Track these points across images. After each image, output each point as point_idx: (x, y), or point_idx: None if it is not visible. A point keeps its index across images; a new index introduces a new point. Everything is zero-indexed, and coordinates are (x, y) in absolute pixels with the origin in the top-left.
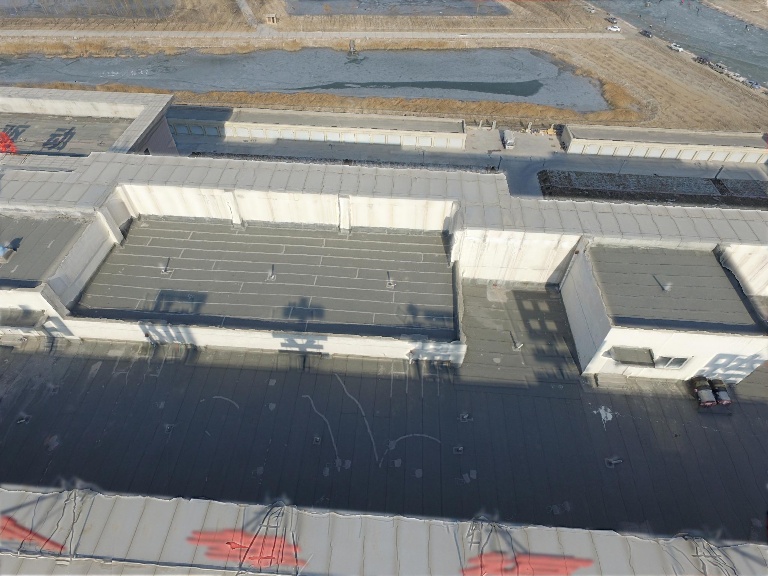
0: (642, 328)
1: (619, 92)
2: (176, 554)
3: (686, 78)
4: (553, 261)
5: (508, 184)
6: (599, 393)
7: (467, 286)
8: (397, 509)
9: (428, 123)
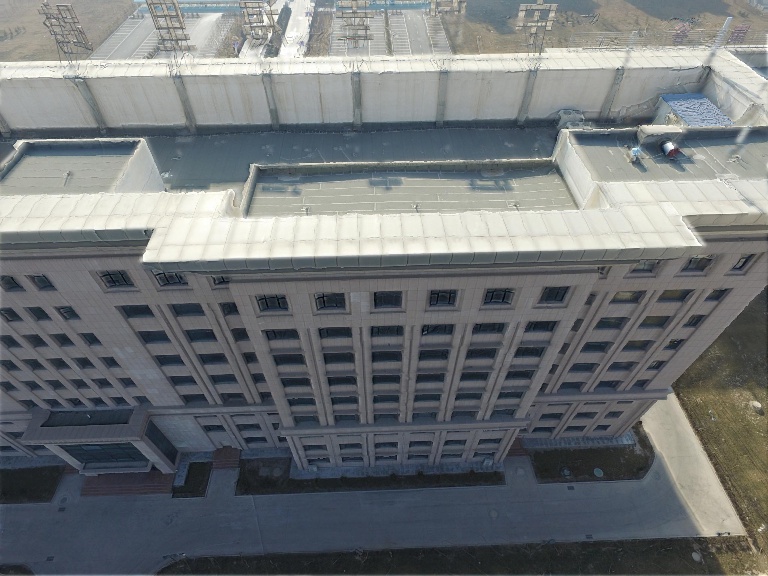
0: (116, 150)
1: None
2: None
3: None
4: None
5: None
6: None
7: None
8: (308, 138)
9: None
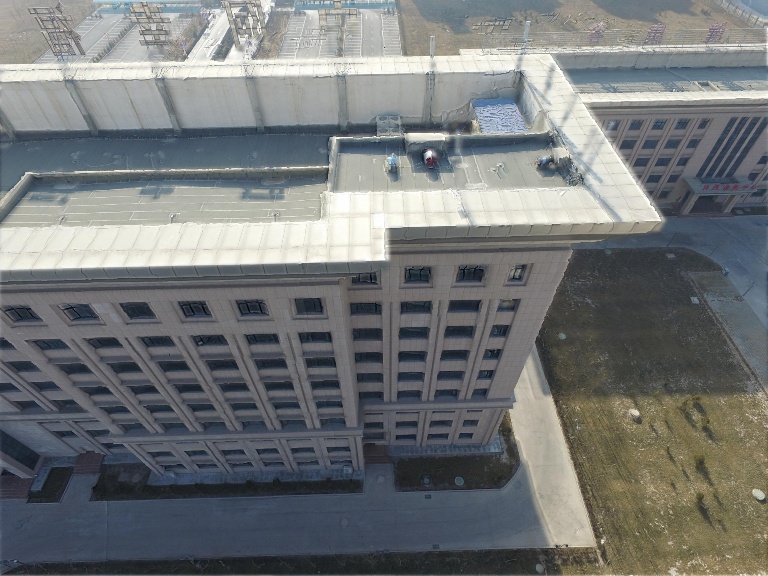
0: None
1: None
2: None
3: None
4: None
5: None
6: None
7: None
8: (124, 144)
9: None
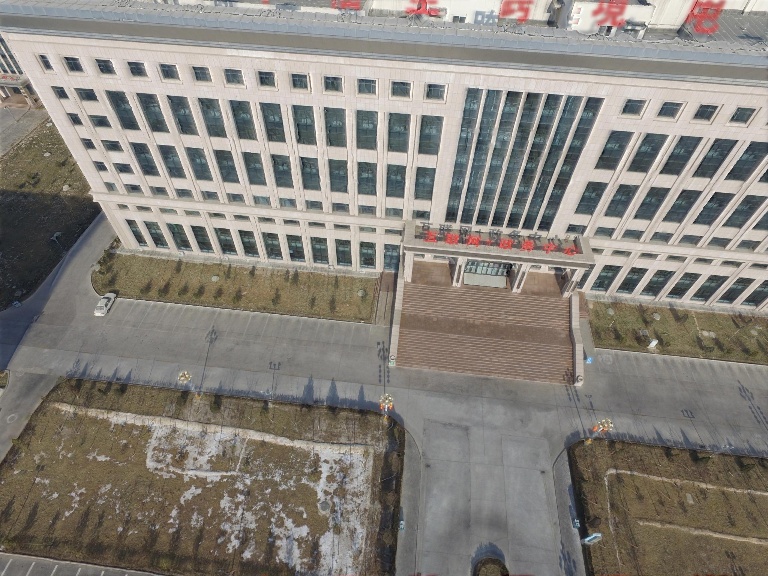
0: None
1: None
2: None
3: None
4: None
5: None
6: None
7: (378, 14)
8: None
9: None
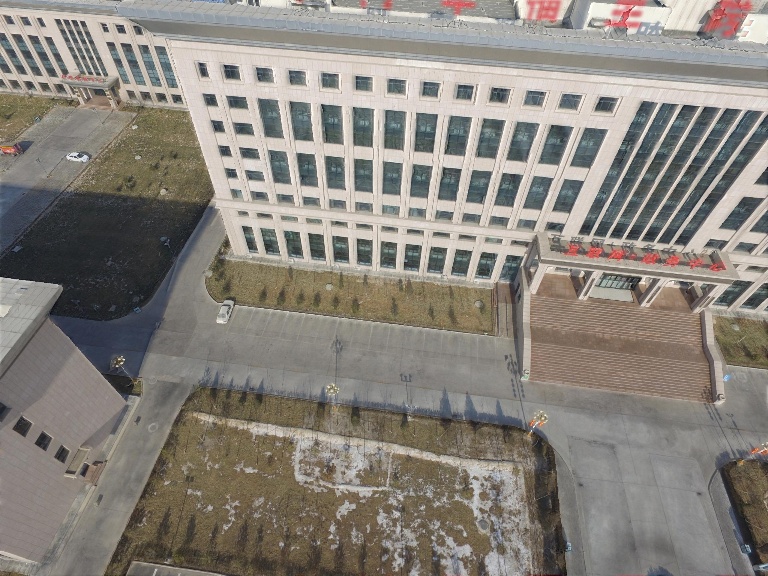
0: None
1: None
2: (424, 24)
3: None
4: (567, 3)
5: None
6: None
7: None
8: None
9: None
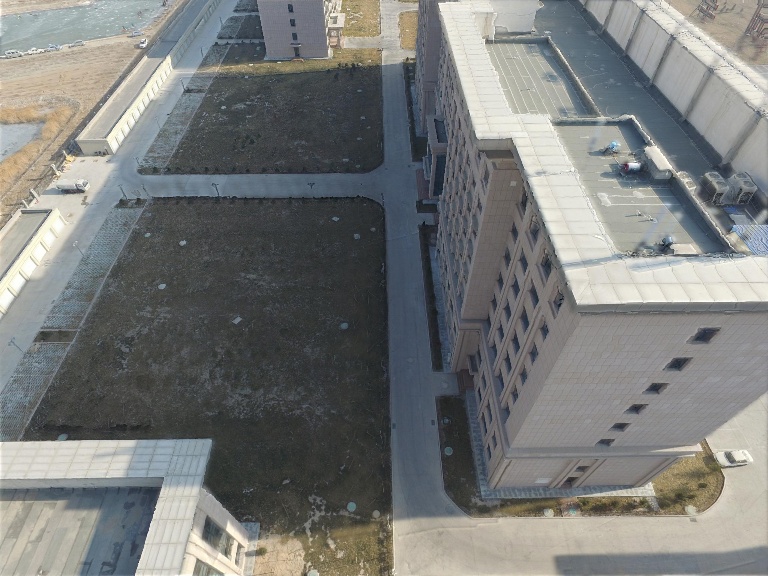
0: None
1: (11, 112)
2: None
3: (16, 73)
4: None
5: (151, 195)
6: (538, 32)
7: None
8: (621, 69)
9: (4, 243)
